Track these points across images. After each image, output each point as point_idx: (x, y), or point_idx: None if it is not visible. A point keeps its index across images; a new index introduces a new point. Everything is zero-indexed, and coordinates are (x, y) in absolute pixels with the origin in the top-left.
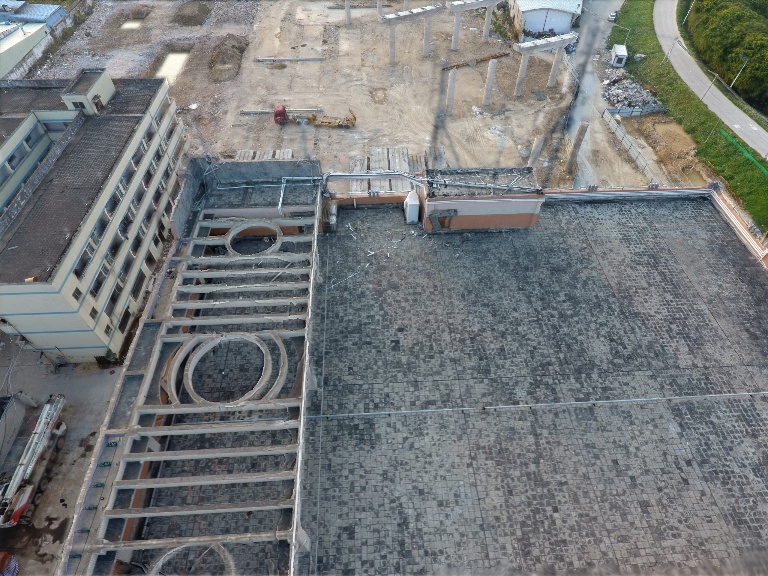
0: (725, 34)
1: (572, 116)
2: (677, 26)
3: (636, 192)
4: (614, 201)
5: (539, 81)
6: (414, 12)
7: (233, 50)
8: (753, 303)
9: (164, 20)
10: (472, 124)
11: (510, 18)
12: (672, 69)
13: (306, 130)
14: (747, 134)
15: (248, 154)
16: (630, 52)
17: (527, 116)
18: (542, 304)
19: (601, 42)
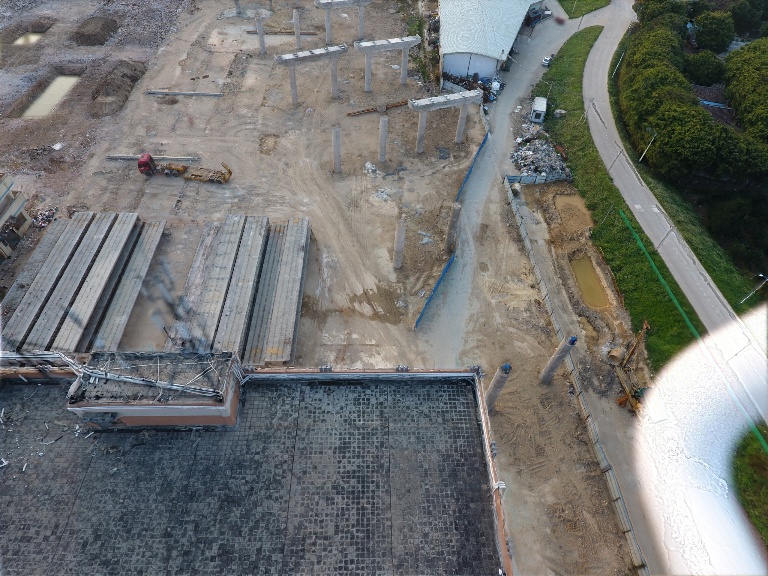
0: (643, 99)
1: (471, 180)
2: (607, 79)
3: (382, 374)
4: (357, 382)
5: (448, 135)
6: (315, 53)
7: (123, 79)
8: (454, 569)
9: (62, 37)
10: (360, 185)
11: (436, 57)
12: (587, 131)
13: (173, 183)
14: (646, 217)
15: (86, 217)
16: (553, 105)
17: (422, 178)
18: (181, 563)
19: (527, 90)
